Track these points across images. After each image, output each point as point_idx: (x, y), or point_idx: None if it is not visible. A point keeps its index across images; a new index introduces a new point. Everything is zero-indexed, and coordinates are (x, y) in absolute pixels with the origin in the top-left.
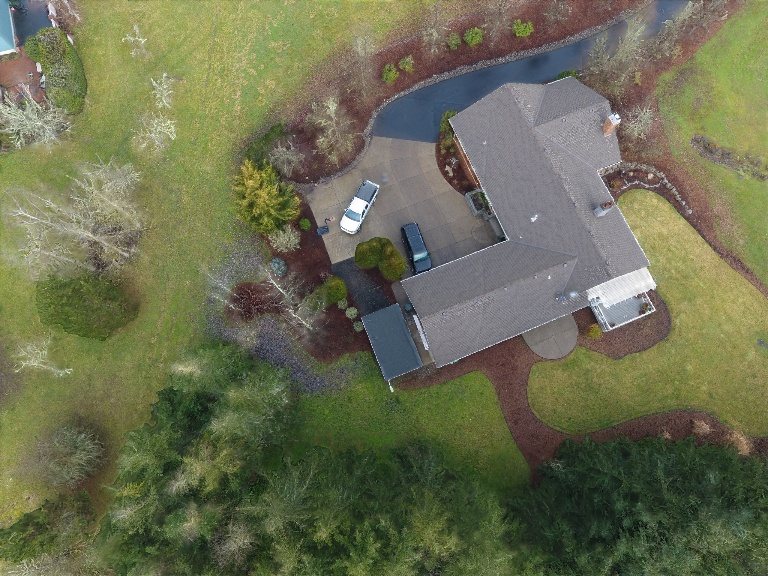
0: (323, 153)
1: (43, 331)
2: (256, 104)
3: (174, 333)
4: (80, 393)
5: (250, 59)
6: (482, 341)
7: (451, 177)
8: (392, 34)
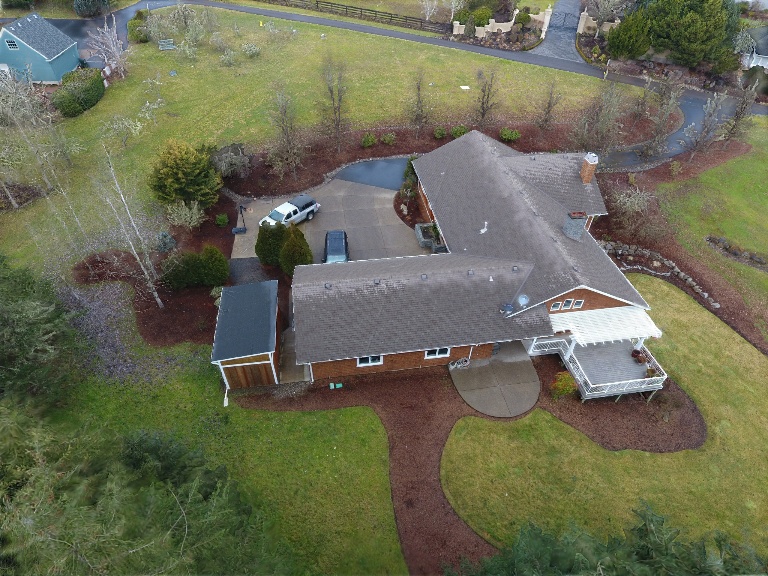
0: (270, 164)
1: None
2: (232, 139)
3: None
4: None
5: (246, 116)
6: (377, 342)
7: (405, 215)
8: (383, 122)
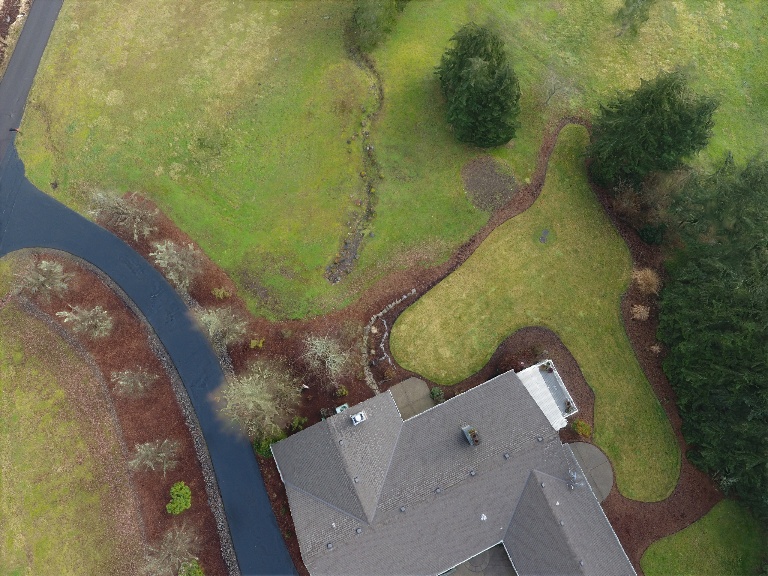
0: None
1: None
2: None
3: None
4: None
5: None
6: None
7: None
8: None
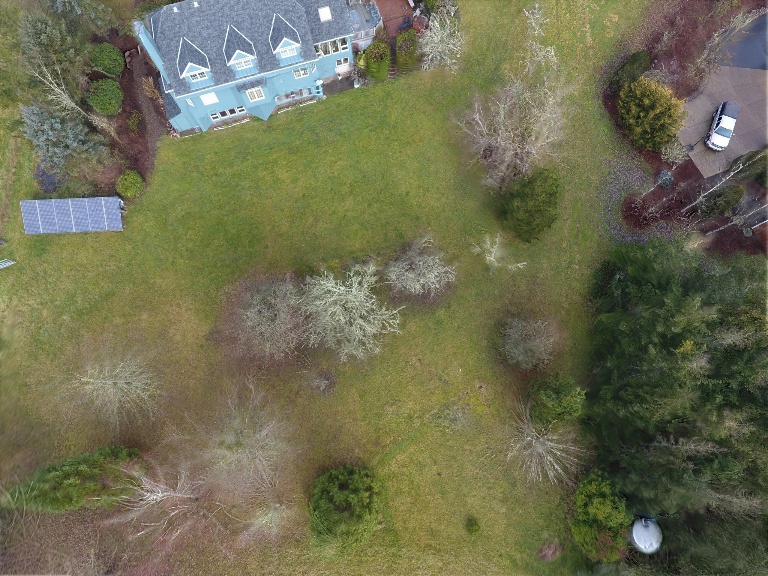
0: (691, 75)
1: (461, 237)
2: (605, 35)
3: (582, 238)
4: (508, 292)
5: None
6: None
7: None
8: None
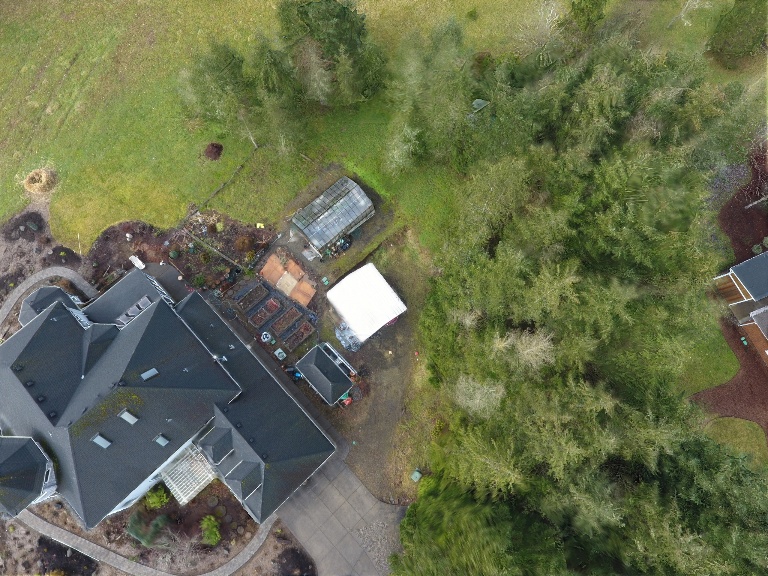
0: None
1: (696, 8)
2: None
3: None
4: None
5: None
6: None
7: None
8: None
